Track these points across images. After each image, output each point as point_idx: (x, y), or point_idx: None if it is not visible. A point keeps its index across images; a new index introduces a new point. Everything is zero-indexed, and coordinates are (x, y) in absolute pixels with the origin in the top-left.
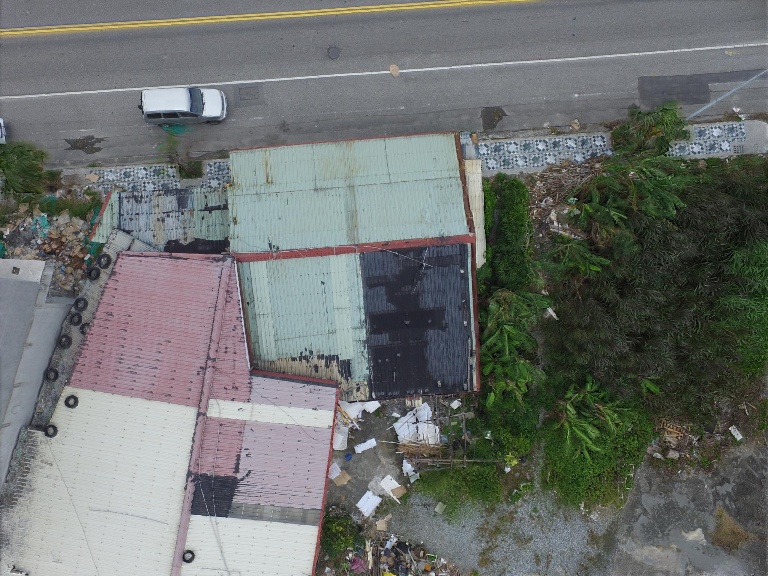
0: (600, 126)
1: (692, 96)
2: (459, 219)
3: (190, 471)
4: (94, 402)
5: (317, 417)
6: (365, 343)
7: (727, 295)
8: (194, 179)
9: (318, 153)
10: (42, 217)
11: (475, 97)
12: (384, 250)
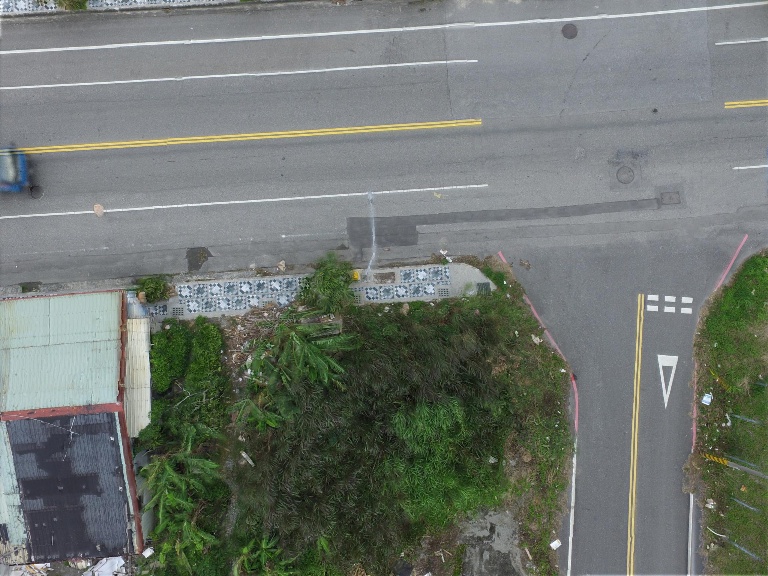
0: (307, 267)
1: (400, 238)
2: (112, 385)
3: None
4: None
5: None
6: (20, 508)
7: (395, 456)
8: None
9: None
10: None
11: (180, 238)
12: (30, 419)
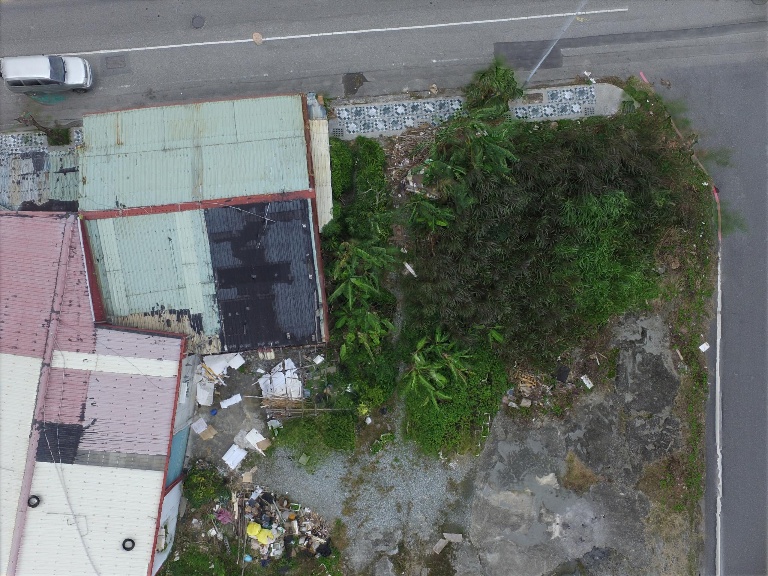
0: (458, 91)
1: (545, 61)
2: (301, 176)
3: (34, 420)
4: None
5: (162, 367)
6: (215, 297)
7: (564, 247)
8: (61, 146)
9: (168, 115)
10: None
11: (336, 64)
12: (227, 206)
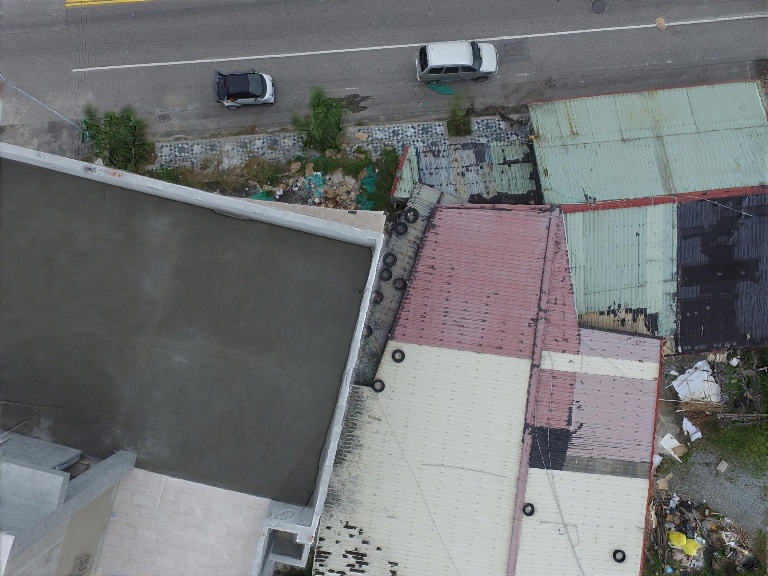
0: None
1: None
2: None
3: (527, 424)
4: (420, 356)
5: (643, 369)
6: (675, 296)
7: None
8: (463, 137)
9: (621, 104)
10: (315, 176)
11: (743, 50)
12: (703, 200)
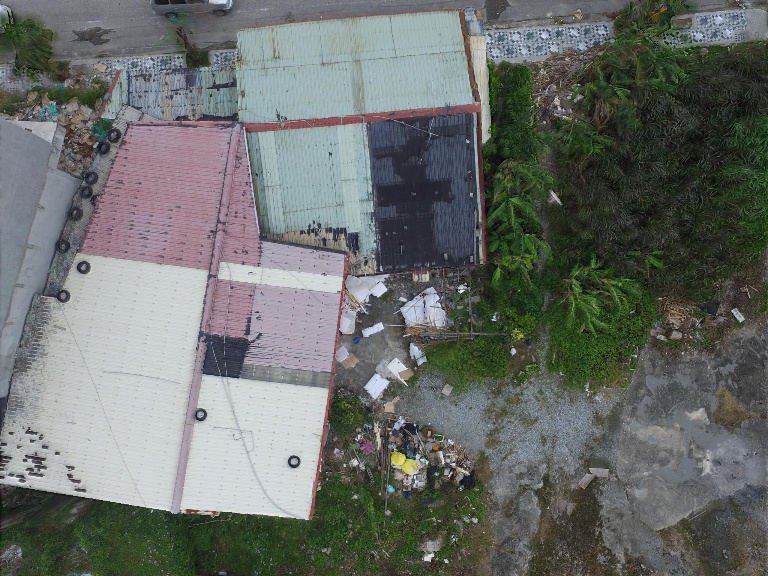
0: (602, 16)
1: None
2: (464, 90)
3: (202, 331)
4: (106, 268)
5: (326, 282)
6: (372, 216)
7: (729, 168)
8: None
9: (324, 30)
10: (51, 105)
11: None
12: (391, 120)
